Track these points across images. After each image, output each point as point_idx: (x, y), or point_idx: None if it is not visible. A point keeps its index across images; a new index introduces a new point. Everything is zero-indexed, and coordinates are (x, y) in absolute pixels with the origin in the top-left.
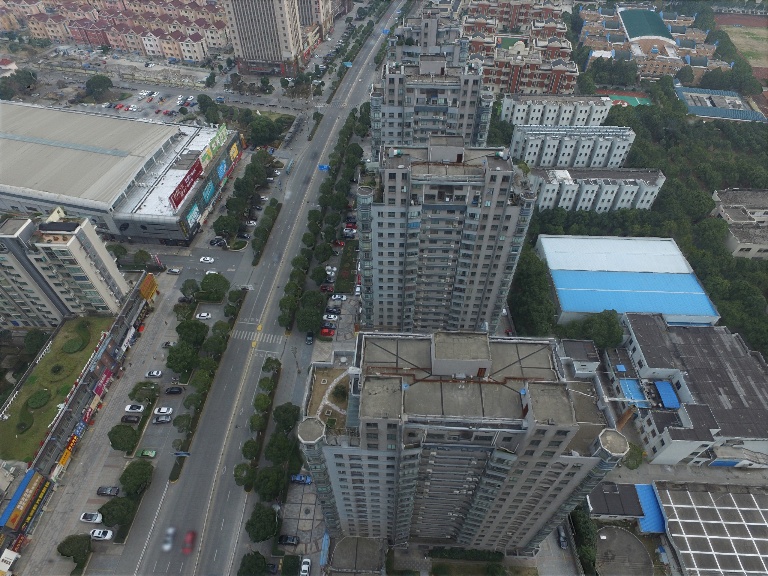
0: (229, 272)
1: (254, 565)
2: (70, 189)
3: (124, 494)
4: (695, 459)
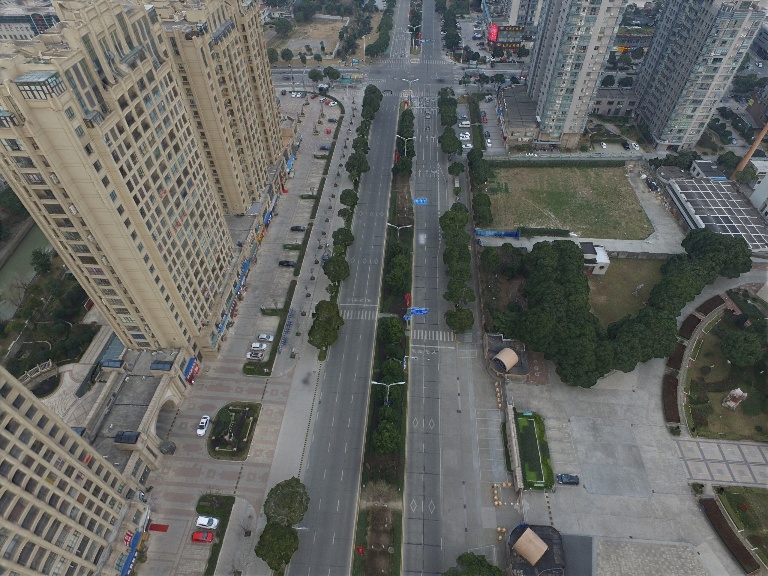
0: (757, 73)
1: (611, 77)
2: (763, 4)
3: (616, 60)
4: (767, 207)
